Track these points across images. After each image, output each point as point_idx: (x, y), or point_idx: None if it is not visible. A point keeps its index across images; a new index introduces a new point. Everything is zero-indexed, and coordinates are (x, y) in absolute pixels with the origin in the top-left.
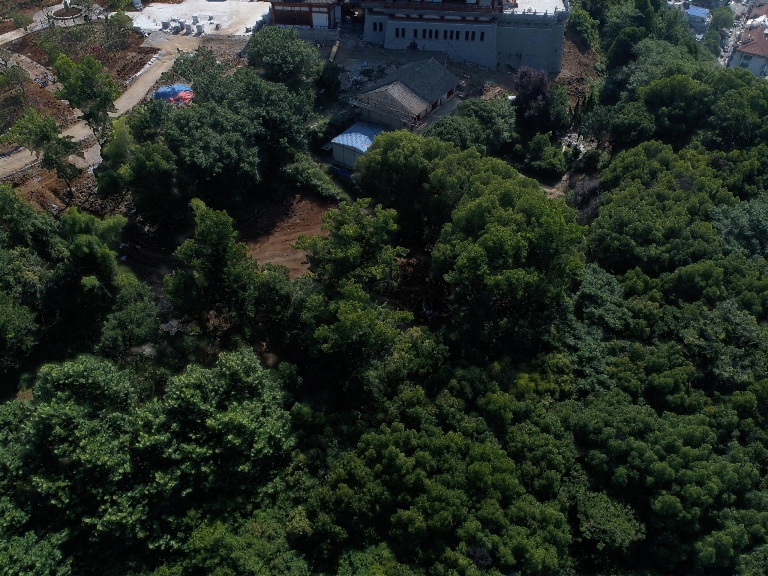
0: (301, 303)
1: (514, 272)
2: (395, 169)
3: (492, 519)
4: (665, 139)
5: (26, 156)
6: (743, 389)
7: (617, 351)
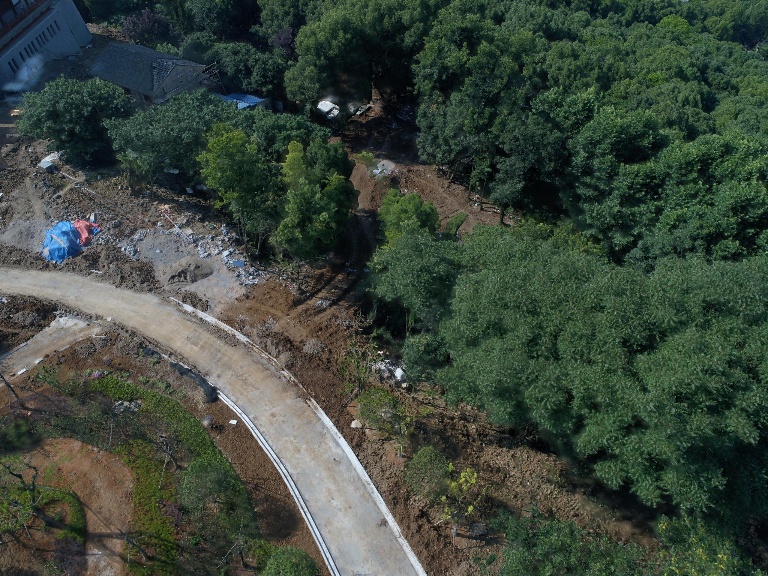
0: None
1: None
2: (359, 34)
3: None
4: (237, 1)
5: (210, 354)
6: None
7: None
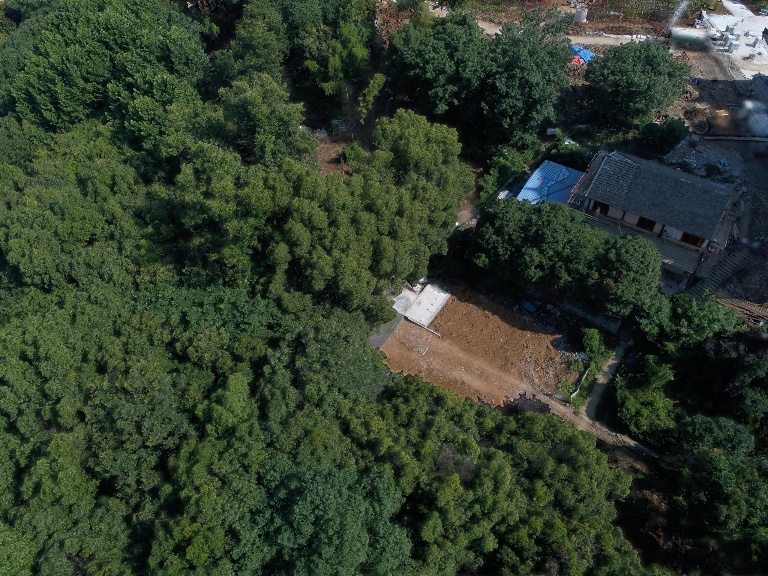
0: None
1: (186, 176)
2: None
3: None
4: None
5: None
6: (83, 418)
7: (168, 324)
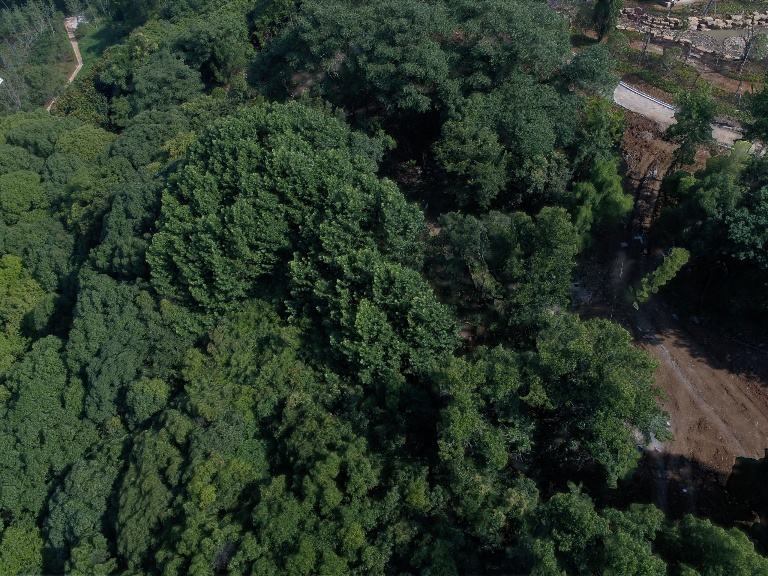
0: (524, 358)
1: None
2: None
3: (252, 571)
4: None
5: (715, 133)
6: None
7: None
